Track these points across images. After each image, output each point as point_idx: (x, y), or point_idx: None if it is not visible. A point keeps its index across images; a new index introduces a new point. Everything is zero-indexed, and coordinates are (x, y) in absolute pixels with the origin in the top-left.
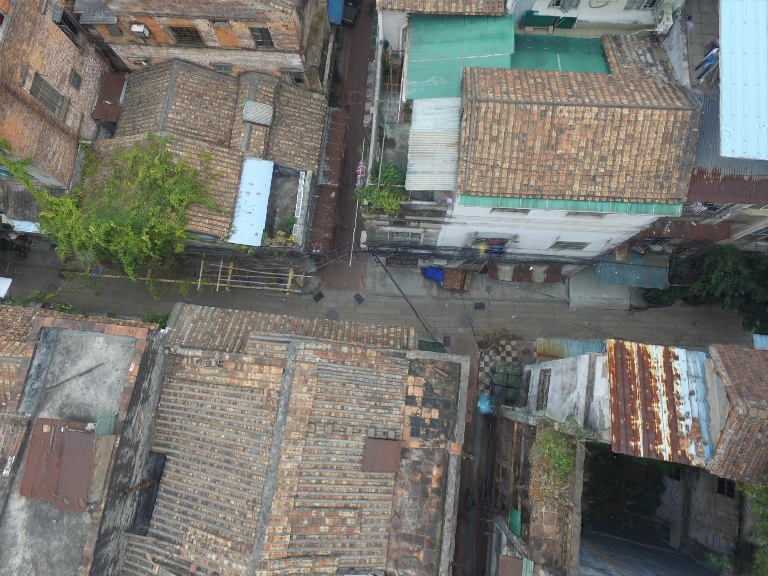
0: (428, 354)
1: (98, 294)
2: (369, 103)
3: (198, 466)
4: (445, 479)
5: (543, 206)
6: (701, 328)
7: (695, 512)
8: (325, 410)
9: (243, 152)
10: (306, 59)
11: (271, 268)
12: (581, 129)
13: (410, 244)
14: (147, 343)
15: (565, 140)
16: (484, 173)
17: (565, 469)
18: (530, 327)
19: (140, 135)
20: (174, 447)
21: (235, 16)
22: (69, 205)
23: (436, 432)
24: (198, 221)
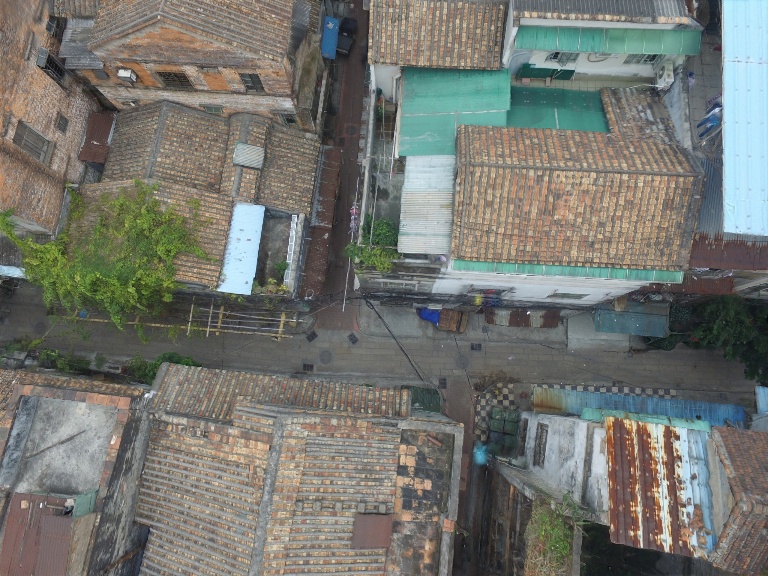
0: (420, 424)
1: (85, 338)
2: (363, 140)
3: (182, 542)
4: (438, 554)
5: (540, 272)
6: (702, 371)
7: (696, 572)
8: (313, 486)
9: (233, 197)
10: (298, 102)
11: (262, 312)
12: (579, 195)
13: (404, 291)
14: (130, 413)
15: (562, 206)
16: (479, 238)
17: (562, 552)
18: (527, 369)
19: (127, 181)
20: (158, 520)
21: (224, 63)
22: (54, 252)
23: (429, 504)
24: (186, 271)
